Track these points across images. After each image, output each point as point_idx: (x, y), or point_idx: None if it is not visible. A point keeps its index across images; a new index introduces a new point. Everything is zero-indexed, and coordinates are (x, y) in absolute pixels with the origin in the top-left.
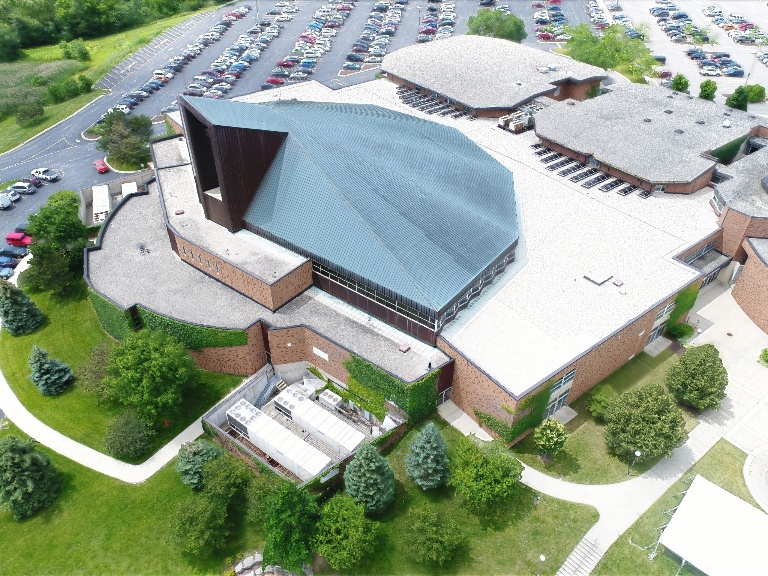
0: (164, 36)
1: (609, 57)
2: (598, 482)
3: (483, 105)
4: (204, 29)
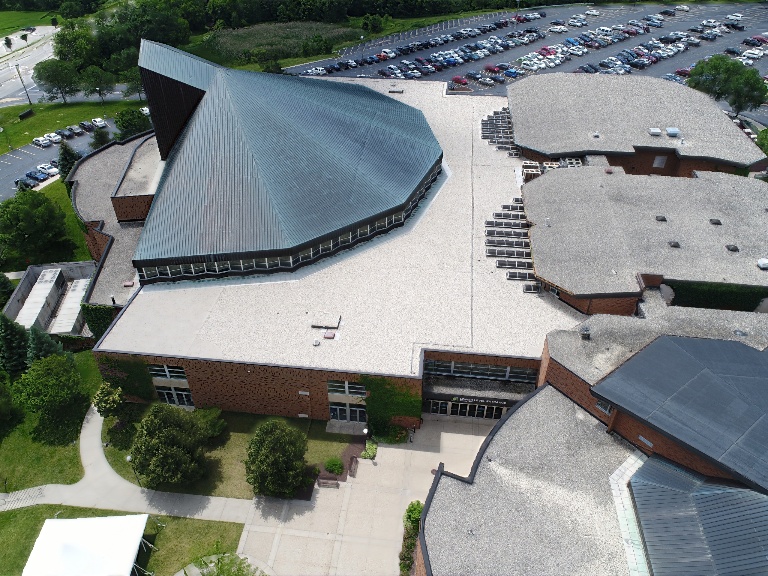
0: (441, 25)
1: None
2: (115, 466)
3: (525, 144)
4: (478, 25)
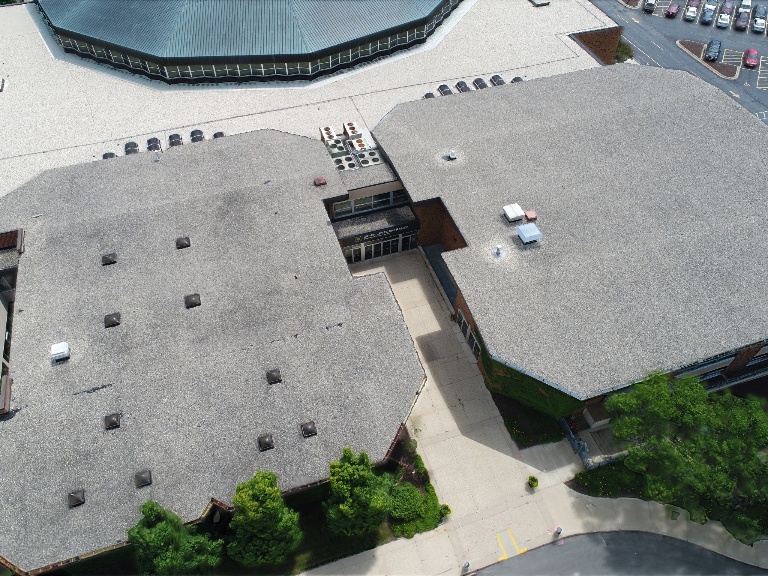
0: None
1: (662, 449)
2: None
3: (397, 109)
4: None
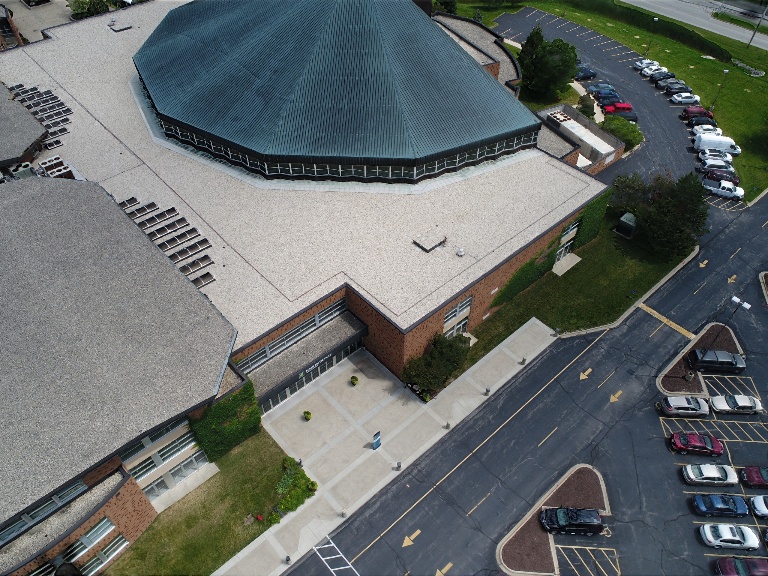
0: None
1: None
2: None
3: (80, 182)
4: None
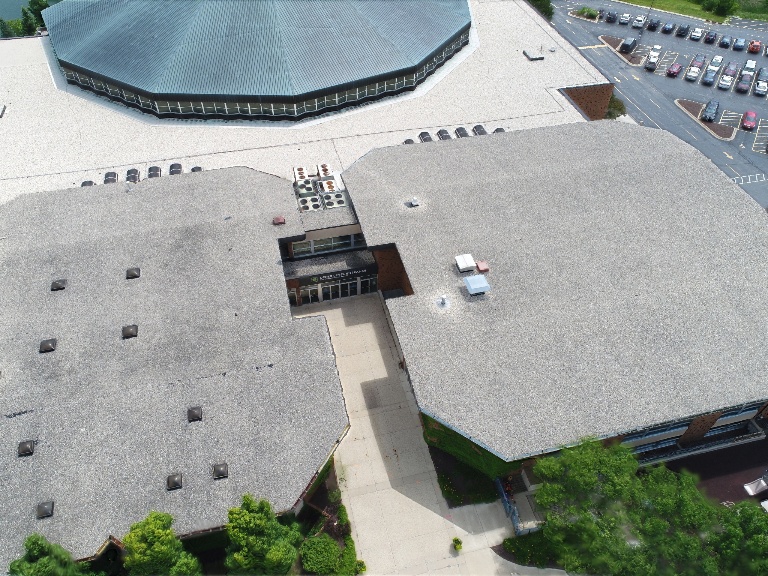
0: None
1: (581, 521)
2: None
3: (371, 154)
4: None
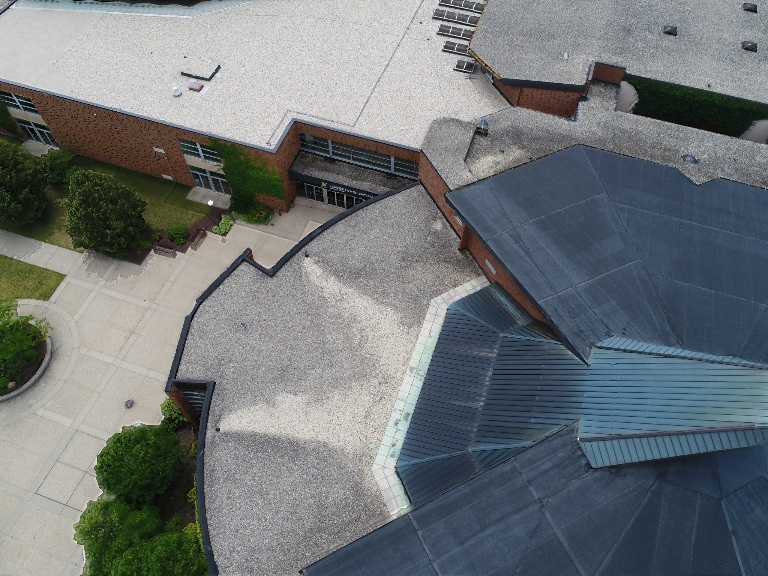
0: None
1: None
2: None
3: None
4: None
